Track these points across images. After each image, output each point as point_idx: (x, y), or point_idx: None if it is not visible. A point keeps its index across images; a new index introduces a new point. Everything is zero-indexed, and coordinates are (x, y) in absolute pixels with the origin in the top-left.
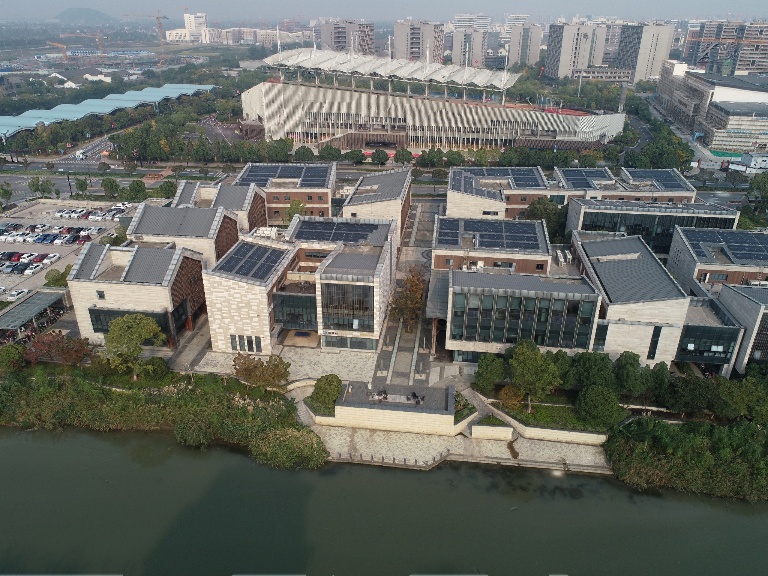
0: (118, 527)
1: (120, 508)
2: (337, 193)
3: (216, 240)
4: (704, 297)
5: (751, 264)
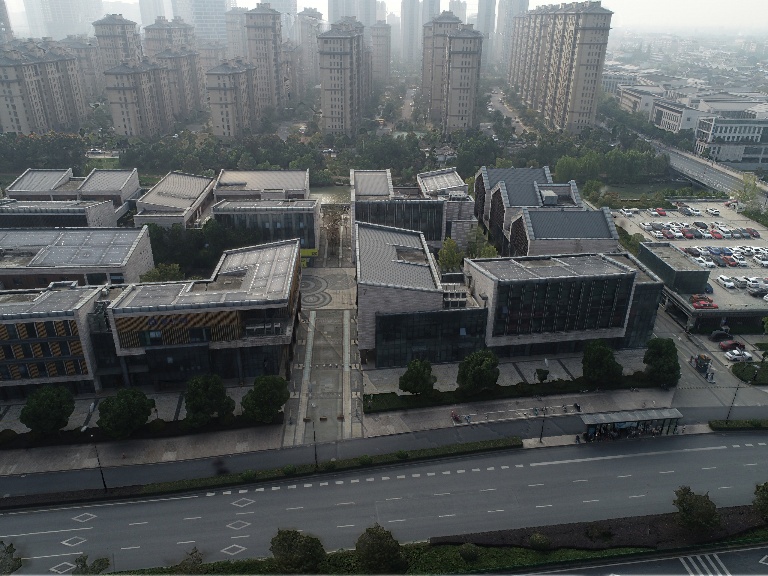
0: None
1: None
2: (475, 304)
3: None
4: None
5: (68, 202)
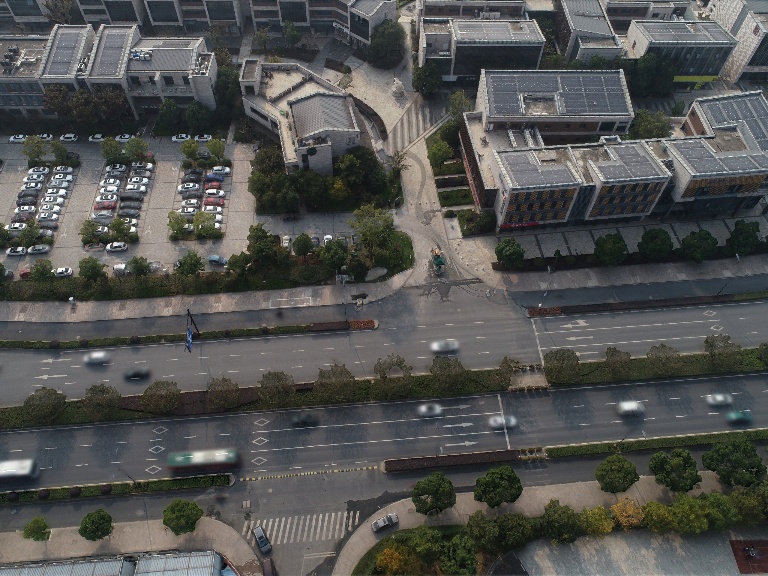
0: None
1: None
2: None
3: None
4: (532, 10)
5: (498, 22)
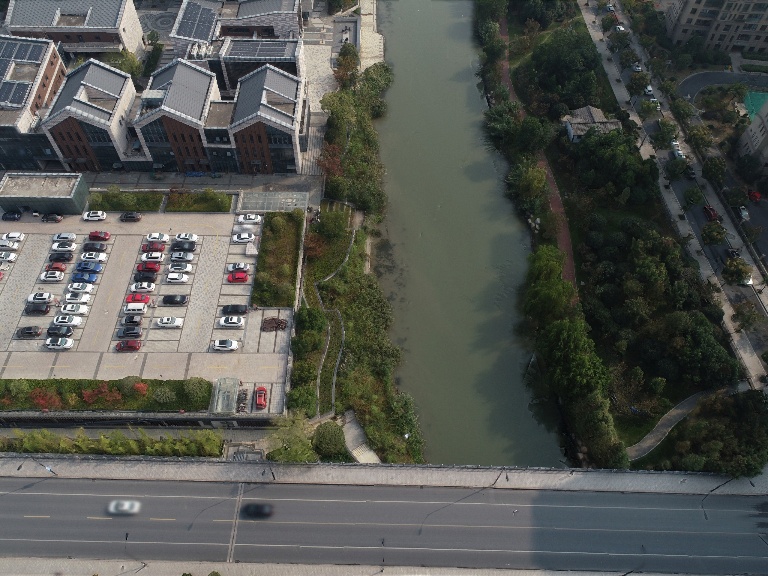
0: (439, 121)
1: (429, 123)
2: None
3: None
4: None
5: None
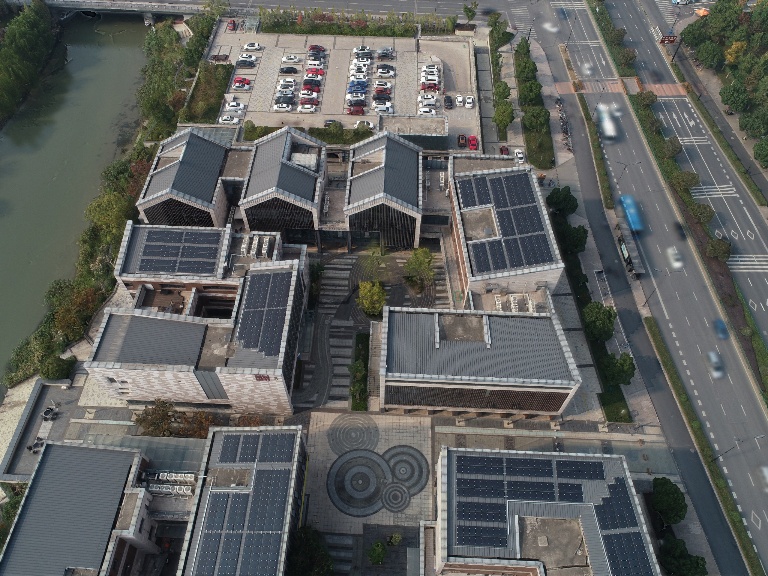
0: None
1: (5, 278)
2: (523, 295)
3: (252, 209)
4: None
5: None
